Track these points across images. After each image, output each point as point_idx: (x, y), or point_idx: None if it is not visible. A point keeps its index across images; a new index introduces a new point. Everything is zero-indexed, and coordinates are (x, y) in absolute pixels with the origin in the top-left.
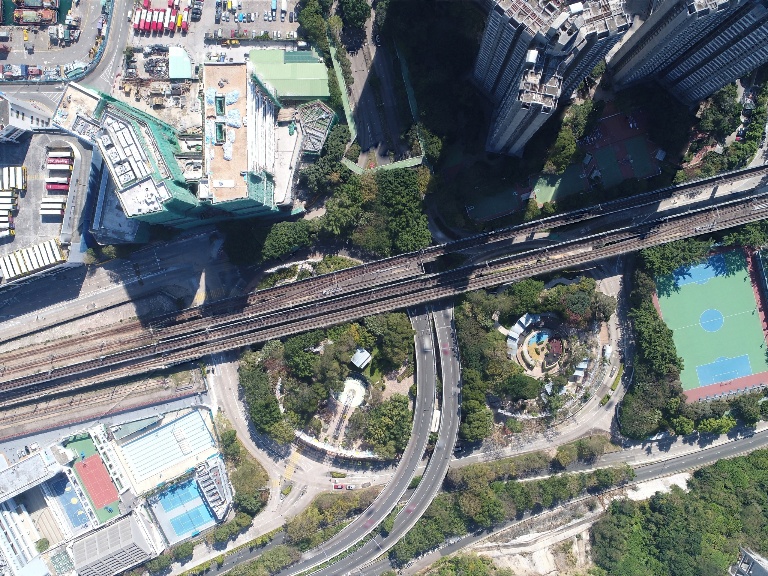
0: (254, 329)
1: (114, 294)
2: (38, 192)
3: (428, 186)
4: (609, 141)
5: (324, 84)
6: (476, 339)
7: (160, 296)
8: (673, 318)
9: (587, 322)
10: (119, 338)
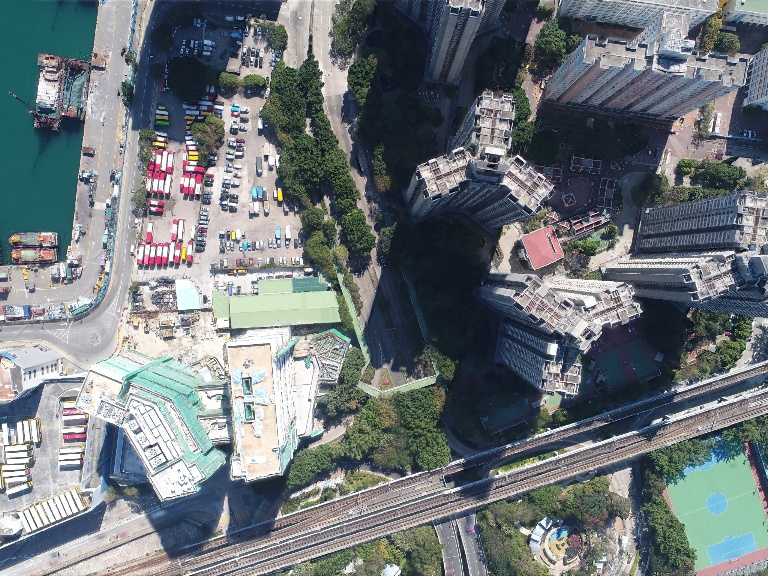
0: (283, 553)
1: (137, 524)
2: (54, 441)
3: (444, 407)
4: (610, 345)
5: (335, 311)
6: (502, 549)
7: (184, 524)
8: (681, 504)
9: (604, 521)
10: (146, 572)
